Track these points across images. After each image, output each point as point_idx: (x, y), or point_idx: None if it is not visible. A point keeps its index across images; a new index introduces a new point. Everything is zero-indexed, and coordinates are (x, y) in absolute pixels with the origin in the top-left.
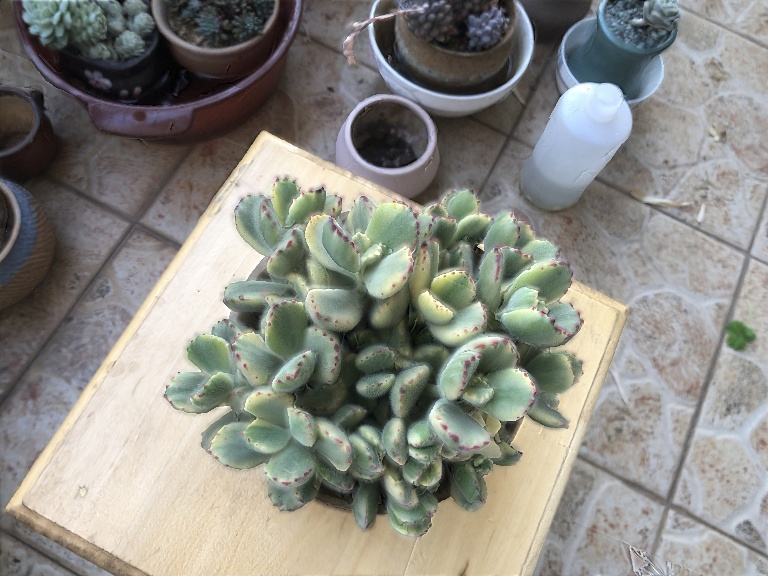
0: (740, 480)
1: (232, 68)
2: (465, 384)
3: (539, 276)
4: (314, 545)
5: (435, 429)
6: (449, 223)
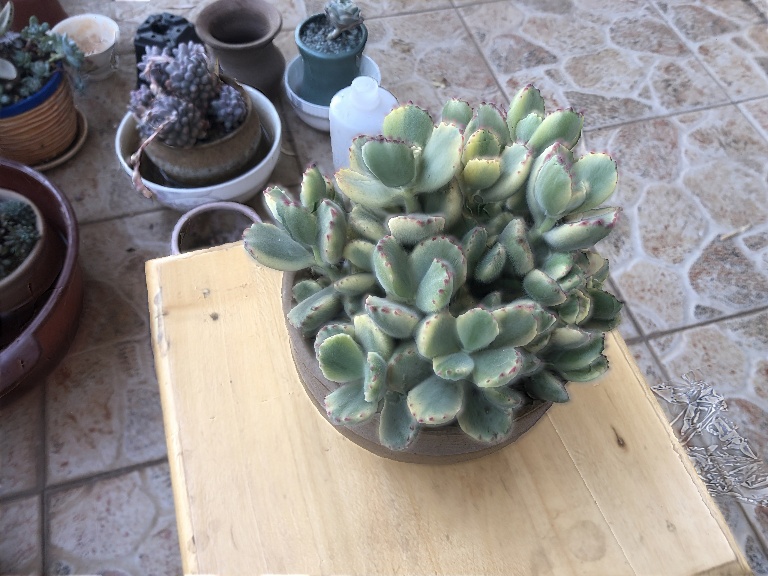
0: (667, 284)
1: (34, 285)
2: None
3: (522, 105)
4: (500, 522)
5: (574, 237)
6: None
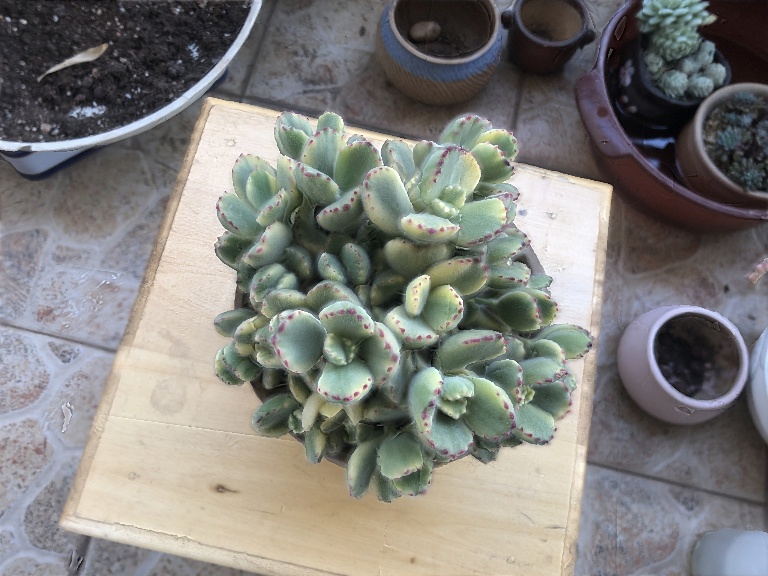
0: None
1: (696, 179)
2: (332, 315)
3: (490, 395)
4: (225, 340)
5: None
6: (533, 312)
